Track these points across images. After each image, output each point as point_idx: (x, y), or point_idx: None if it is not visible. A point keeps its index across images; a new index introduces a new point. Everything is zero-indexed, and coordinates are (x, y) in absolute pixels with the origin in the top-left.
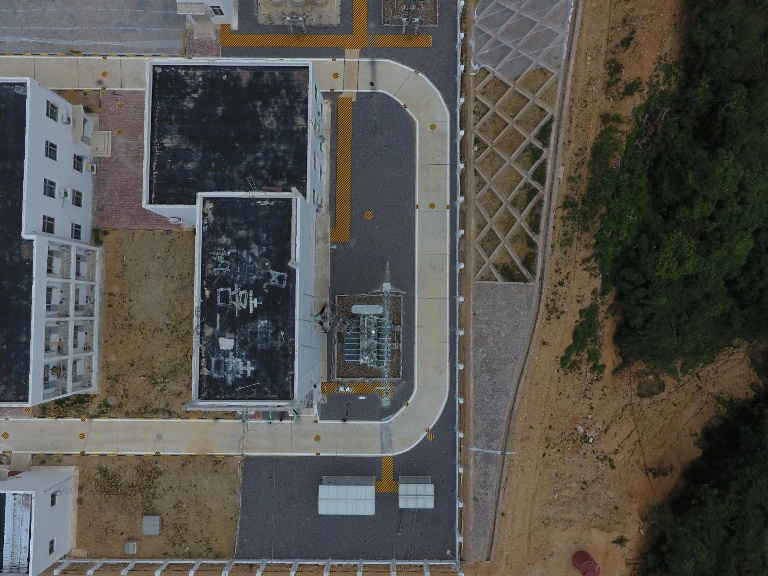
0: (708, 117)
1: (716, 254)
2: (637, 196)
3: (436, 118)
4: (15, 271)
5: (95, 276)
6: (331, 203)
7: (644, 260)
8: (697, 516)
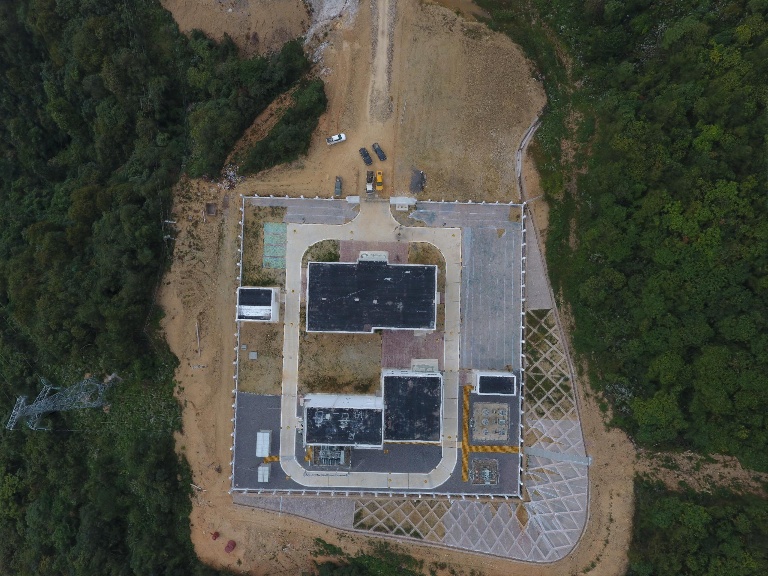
0: None
1: None
2: (388, 575)
3: (430, 483)
4: (359, 322)
5: None
6: None
7: None
8: None
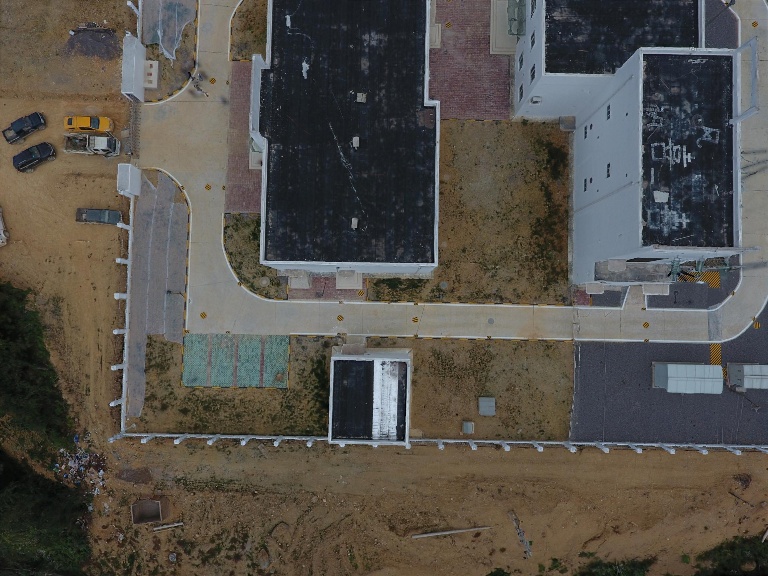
0: None
1: None
2: None
3: (758, 15)
4: (411, 138)
5: None
6: None
7: None
8: None
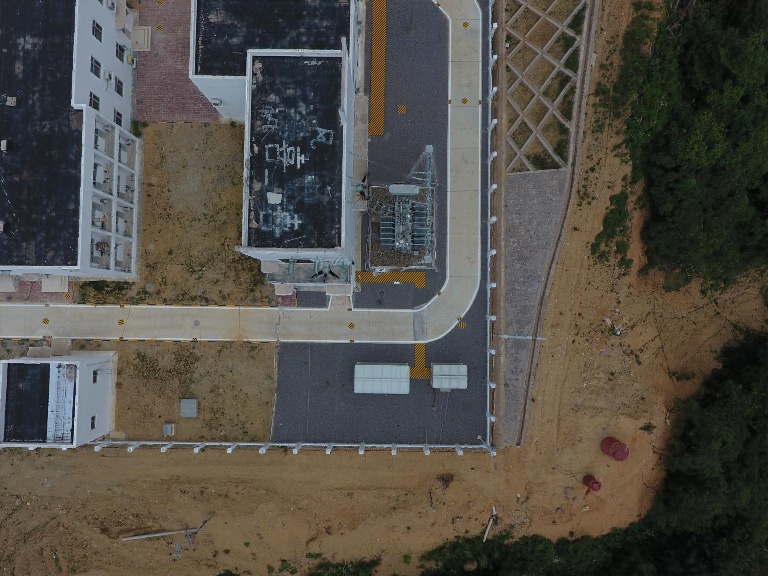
0: (737, 5)
1: (743, 147)
2: (668, 82)
3: (468, 16)
4: (64, 141)
5: (135, 166)
6: None
7: (675, 142)
8: (722, 407)
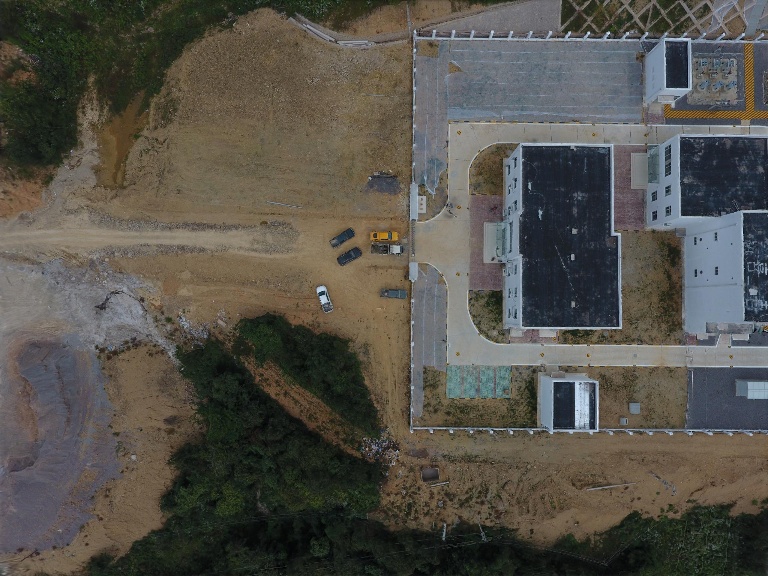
0: None
1: None
2: None
3: None
4: (603, 254)
5: None
6: None
7: None
8: None
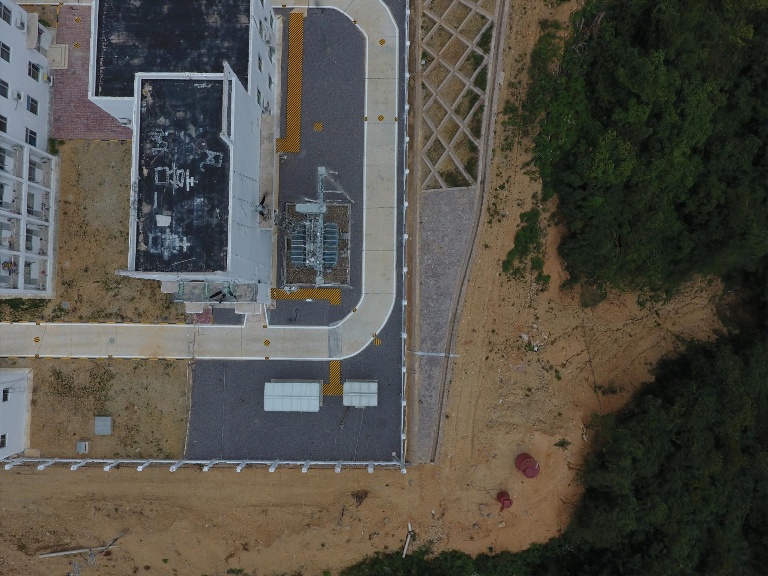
0: (643, 23)
1: (656, 163)
2: (575, 100)
3: (385, 33)
4: None
5: (50, 183)
6: (282, 115)
7: (580, 161)
8: (639, 423)
